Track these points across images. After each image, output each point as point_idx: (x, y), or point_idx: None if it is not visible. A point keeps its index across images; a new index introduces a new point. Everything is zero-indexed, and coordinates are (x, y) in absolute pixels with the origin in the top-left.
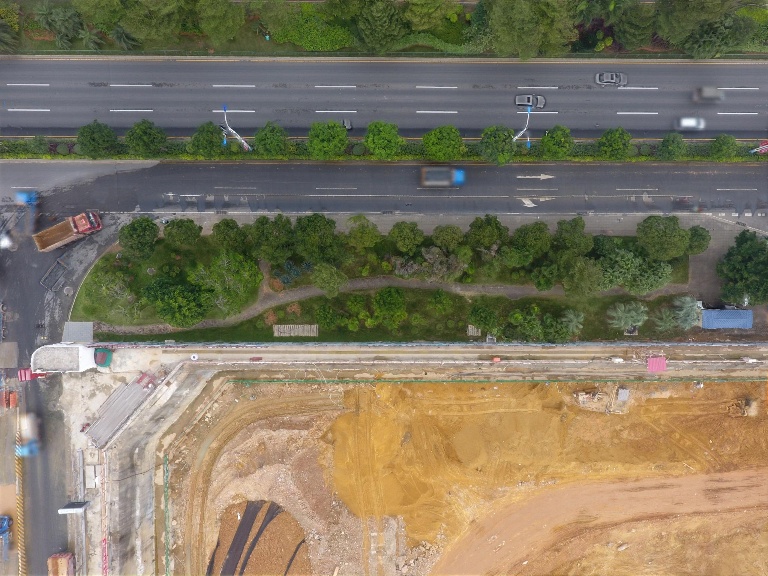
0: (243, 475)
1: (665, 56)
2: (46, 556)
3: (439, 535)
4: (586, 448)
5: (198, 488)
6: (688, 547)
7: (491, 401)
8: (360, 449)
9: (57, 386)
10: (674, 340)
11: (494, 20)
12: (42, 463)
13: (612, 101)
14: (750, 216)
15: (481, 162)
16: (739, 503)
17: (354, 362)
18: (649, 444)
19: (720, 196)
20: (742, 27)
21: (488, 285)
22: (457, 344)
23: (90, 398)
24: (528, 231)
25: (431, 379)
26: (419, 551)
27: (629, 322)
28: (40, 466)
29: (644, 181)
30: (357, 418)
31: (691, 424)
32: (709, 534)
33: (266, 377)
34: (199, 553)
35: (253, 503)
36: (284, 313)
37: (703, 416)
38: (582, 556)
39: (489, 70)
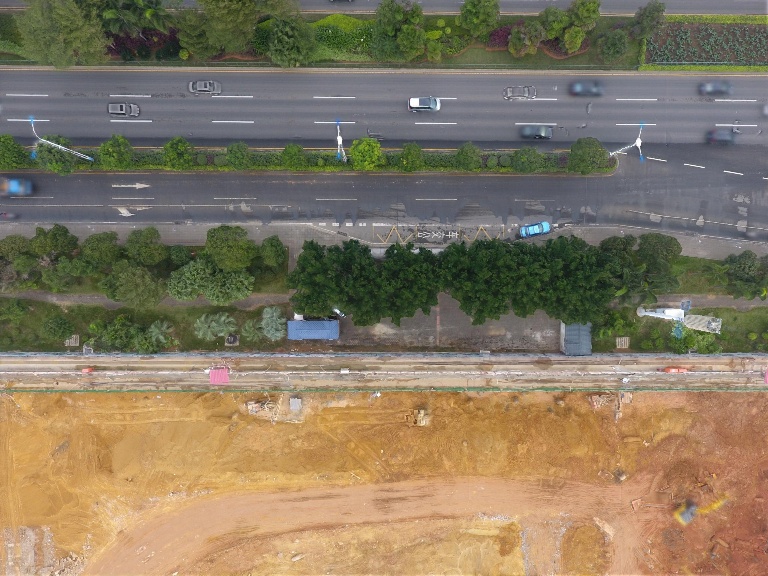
0: None
1: (256, 64)
2: None
3: (84, 546)
4: (252, 458)
5: None
6: (370, 557)
7: (155, 410)
8: None
9: None
10: (275, 351)
11: (20, 29)
12: None
13: (207, 110)
14: (351, 226)
15: (74, 171)
16: (411, 513)
17: None
18: (322, 453)
19: (319, 206)
20: (296, 36)
21: (85, 295)
22: (38, 355)
23: None
24: (90, 241)
25: (62, 389)
26: (67, 562)
27: (208, 333)
28: None
29: (242, 190)
30: None
31: (367, 433)
32: (390, 544)
33: None
34: None
35: None
36: None
37: (379, 425)
38: (252, 566)
39: (80, 78)
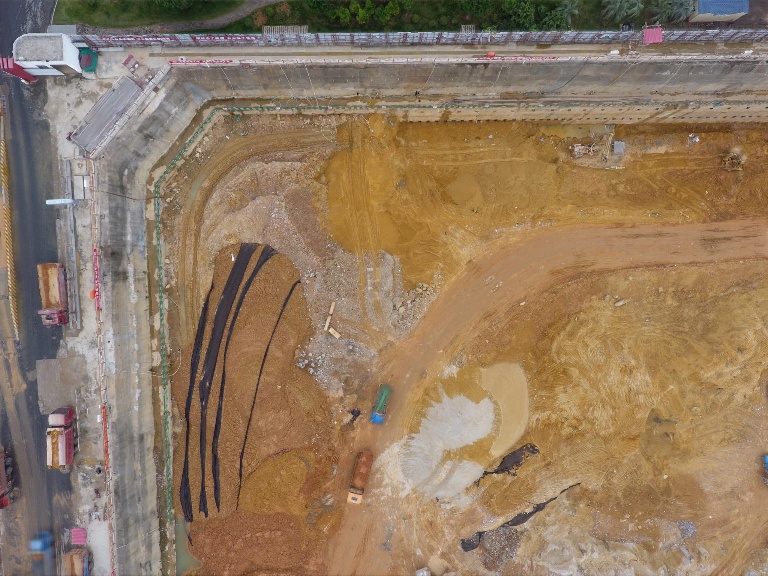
0: (236, 210)
1: None
2: (36, 272)
3: (436, 275)
4: (582, 198)
5: (190, 228)
6: (685, 306)
7: (486, 151)
8: (354, 184)
9: (41, 94)
10: None
11: None
12: (29, 175)
13: None
14: None
15: None
16: (735, 254)
17: (346, 63)
18: (645, 197)
19: None
20: None
21: None
22: (450, 33)
23: (76, 106)
24: None
25: None
26: (416, 293)
27: (624, 5)
28: (27, 178)
29: None
30: (351, 154)
31: (687, 178)
32: (706, 292)
33: (257, 106)
34: (193, 295)
35: (247, 245)
36: (273, 10)
37: (699, 170)
38: (580, 310)
39: None
